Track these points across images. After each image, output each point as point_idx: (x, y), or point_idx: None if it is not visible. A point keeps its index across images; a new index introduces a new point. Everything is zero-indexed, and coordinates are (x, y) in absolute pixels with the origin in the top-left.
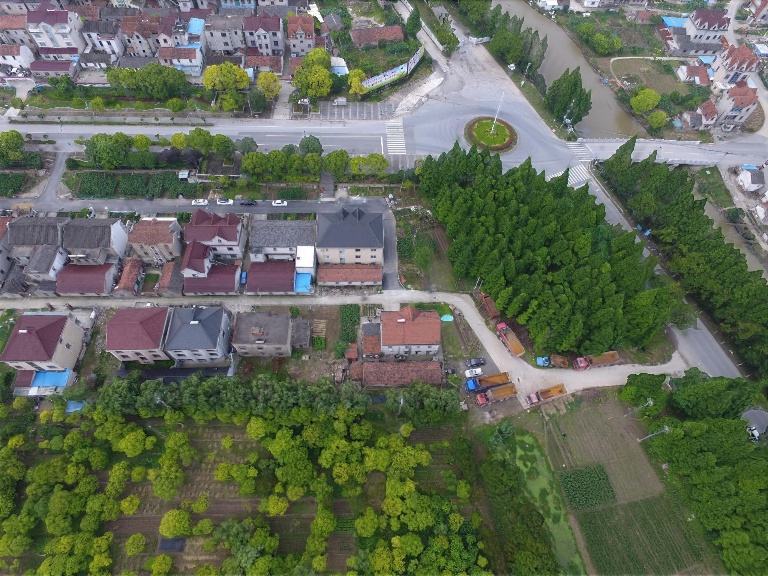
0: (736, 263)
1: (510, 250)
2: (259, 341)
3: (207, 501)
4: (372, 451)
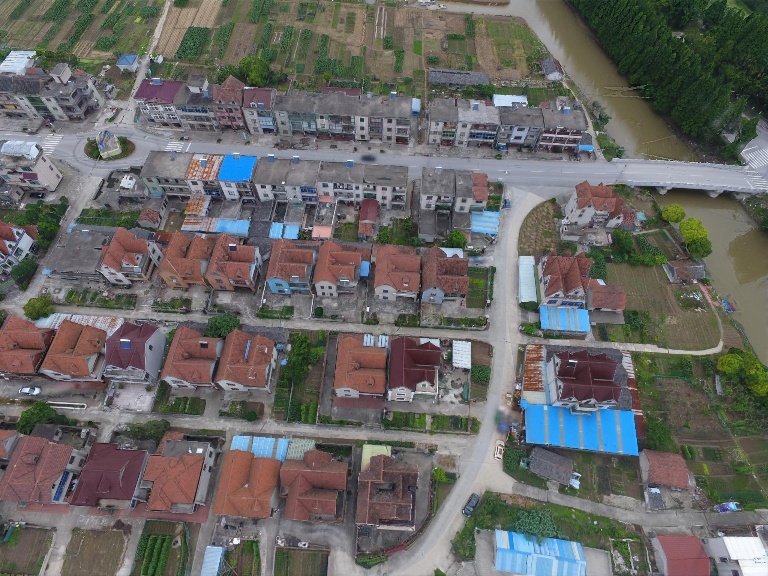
0: (669, 40)
1: None
2: None
3: None
4: None
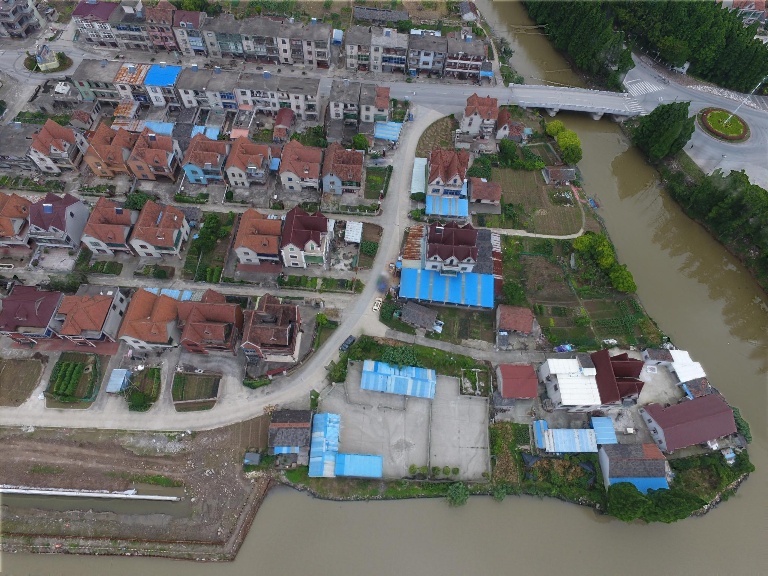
0: None
1: None
2: None
3: None
4: None
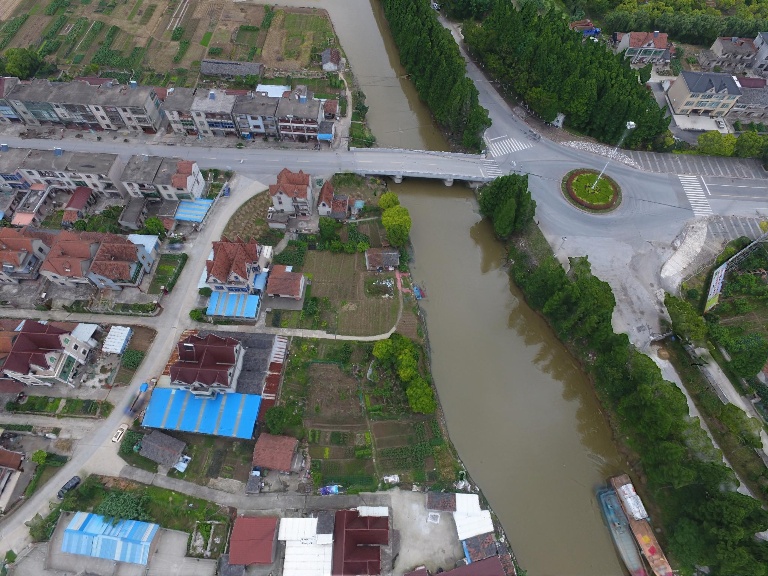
0: (431, 29)
1: (592, 52)
2: (736, 38)
3: (720, 1)
4: (650, 7)
